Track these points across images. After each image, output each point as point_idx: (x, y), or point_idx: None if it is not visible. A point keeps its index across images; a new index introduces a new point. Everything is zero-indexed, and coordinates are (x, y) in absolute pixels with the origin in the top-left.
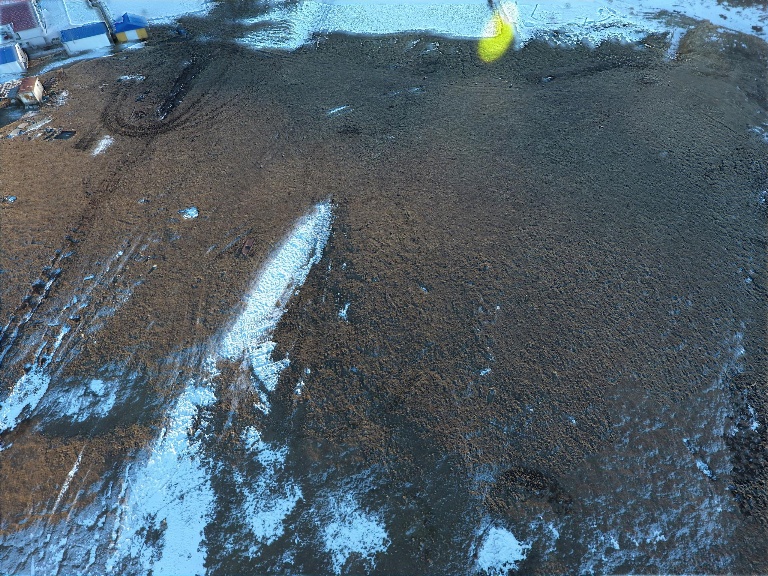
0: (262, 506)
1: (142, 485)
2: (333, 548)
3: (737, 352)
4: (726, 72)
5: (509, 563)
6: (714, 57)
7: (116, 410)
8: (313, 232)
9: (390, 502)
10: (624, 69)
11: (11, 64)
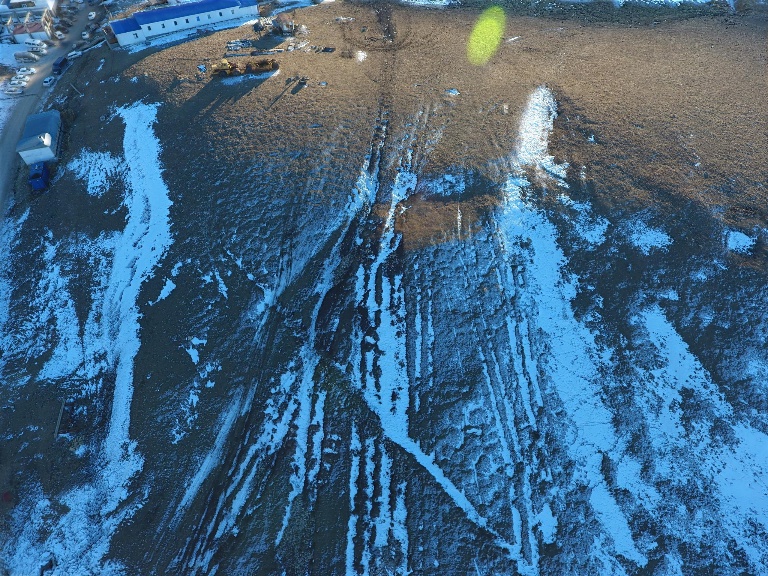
0: (587, 229)
1: (506, 223)
2: (640, 244)
3: None
4: None
5: (746, 246)
6: (767, 13)
7: (469, 189)
8: (544, 103)
9: (666, 223)
10: (709, 17)
11: (253, 7)
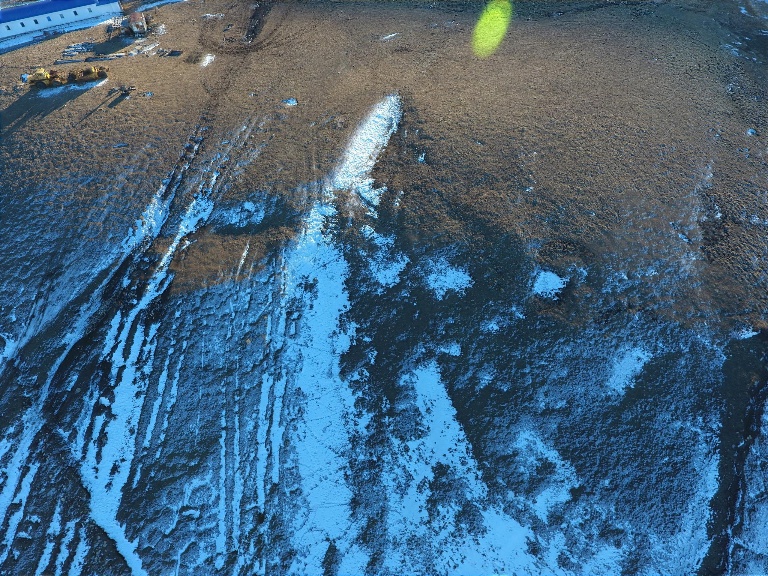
0: (383, 267)
1: (295, 260)
2: (435, 287)
3: (708, 176)
4: (704, 9)
5: (555, 289)
6: None
7: (267, 219)
8: (388, 113)
9: (471, 261)
10: (620, 6)
11: (113, 4)
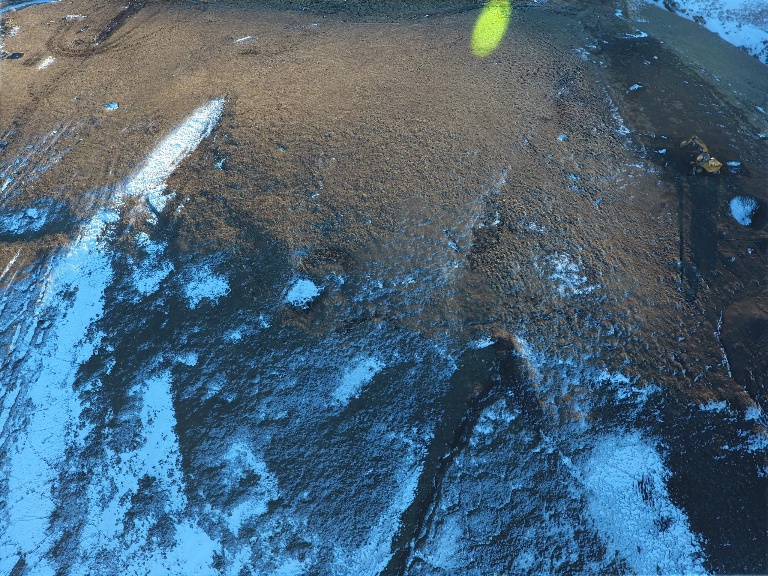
0: (145, 275)
1: (62, 268)
2: (191, 295)
3: (499, 182)
4: (576, 12)
5: (308, 298)
6: (573, 2)
7: (46, 226)
8: (207, 118)
9: (234, 269)
10: (489, 8)
11: None
